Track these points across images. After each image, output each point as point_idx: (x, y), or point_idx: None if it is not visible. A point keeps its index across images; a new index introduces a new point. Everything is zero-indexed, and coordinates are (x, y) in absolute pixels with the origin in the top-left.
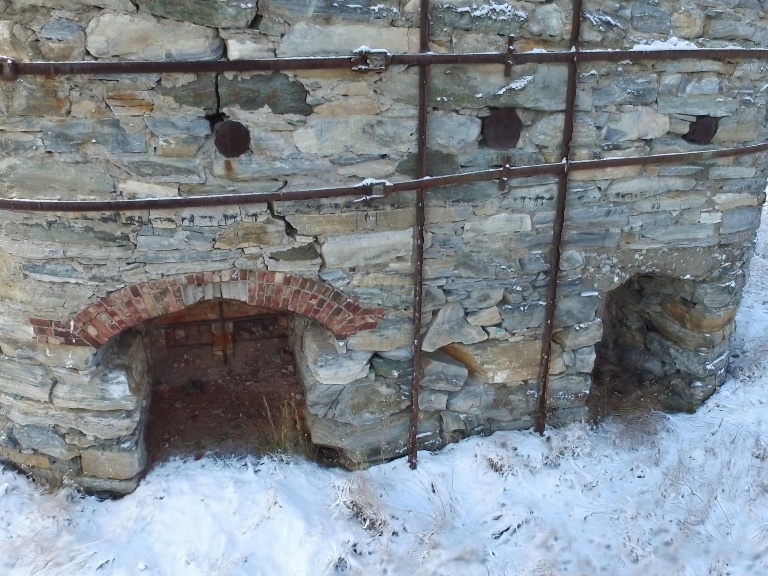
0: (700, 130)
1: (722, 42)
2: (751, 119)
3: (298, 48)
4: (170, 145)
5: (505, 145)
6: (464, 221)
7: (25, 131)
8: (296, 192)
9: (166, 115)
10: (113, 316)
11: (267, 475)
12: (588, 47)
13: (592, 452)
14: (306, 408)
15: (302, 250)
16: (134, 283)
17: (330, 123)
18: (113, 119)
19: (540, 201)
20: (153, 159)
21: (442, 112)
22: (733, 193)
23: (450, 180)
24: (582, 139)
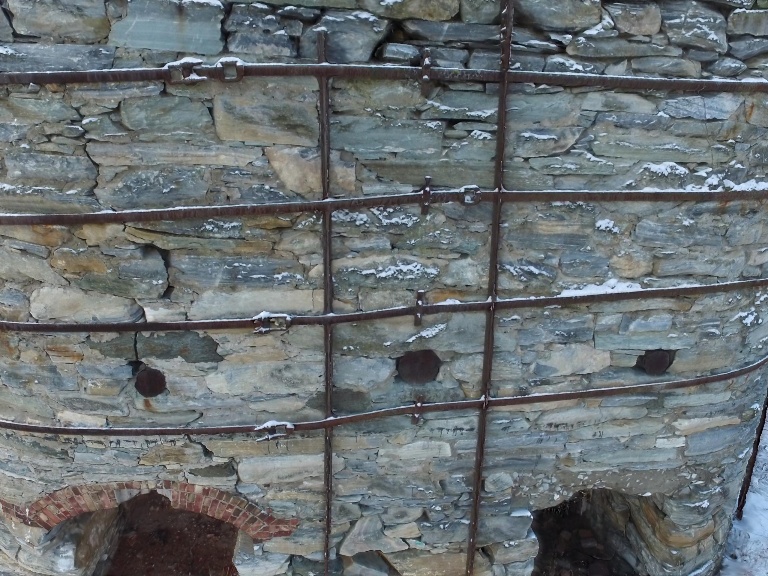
0: (650, 363)
1: (674, 280)
2: (717, 350)
3: (207, 311)
4: (97, 387)
5: (422, 380)
6: (378, 448)
7: None
8: (205, 429)
9: (94, 364)
10: (60, 507)
11: None
12: (509, 294)
13: None
14: None
15: (219, 468)
16: (75, 485)
17: (239, 369)
18: (51, 366)
19: (459, 431)
20: (84, 396)
21: (351, 357)
22: (700, 418)
23: (356, 419)
24: (506, 375)
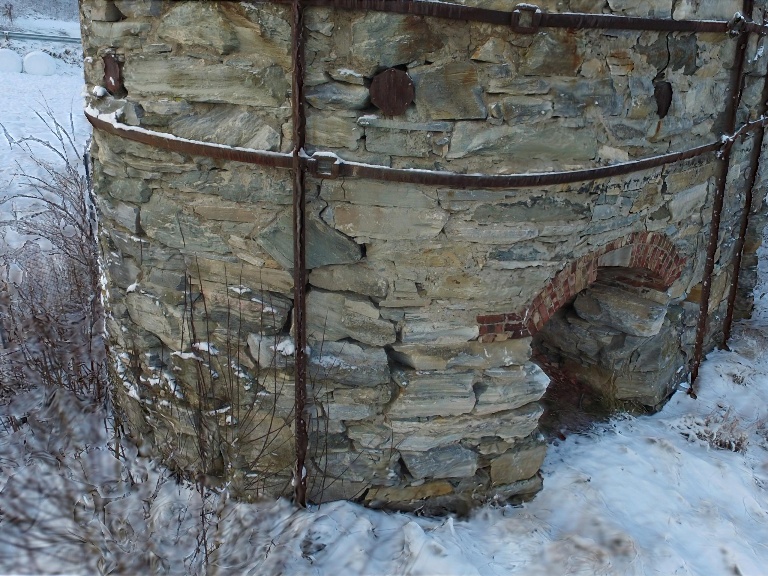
0: None
1: None
2: None
3: (705, 11)
4: (637, 106)
5: None
6: None
7: (533, 93)
8: (691, 150)
9: (640, 75)
10: (553, 298)
11: (631, 433)
12: None
13: (761, 355)
14: (587, 371)
15: (664, 208)
16: (576, 258)
17: None
18: (611, 79)
19: (746, 152)
20: (624, 122)
21: None
22: None
23: None
24: None
